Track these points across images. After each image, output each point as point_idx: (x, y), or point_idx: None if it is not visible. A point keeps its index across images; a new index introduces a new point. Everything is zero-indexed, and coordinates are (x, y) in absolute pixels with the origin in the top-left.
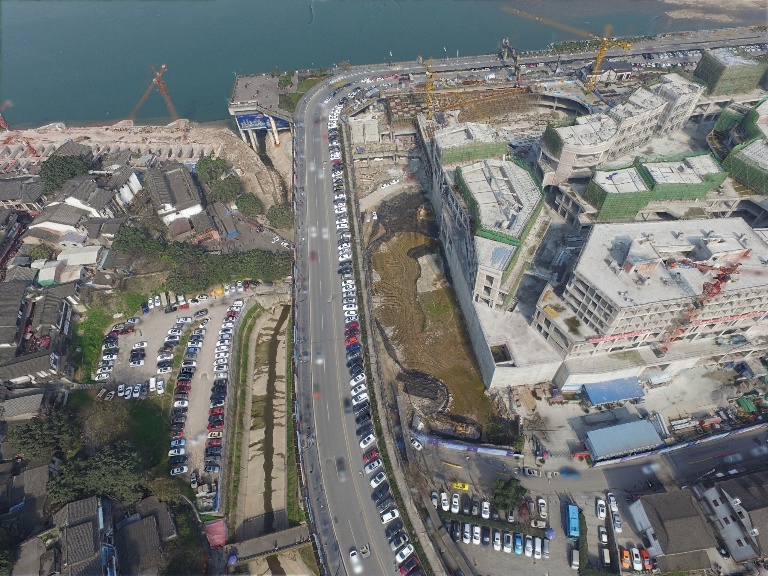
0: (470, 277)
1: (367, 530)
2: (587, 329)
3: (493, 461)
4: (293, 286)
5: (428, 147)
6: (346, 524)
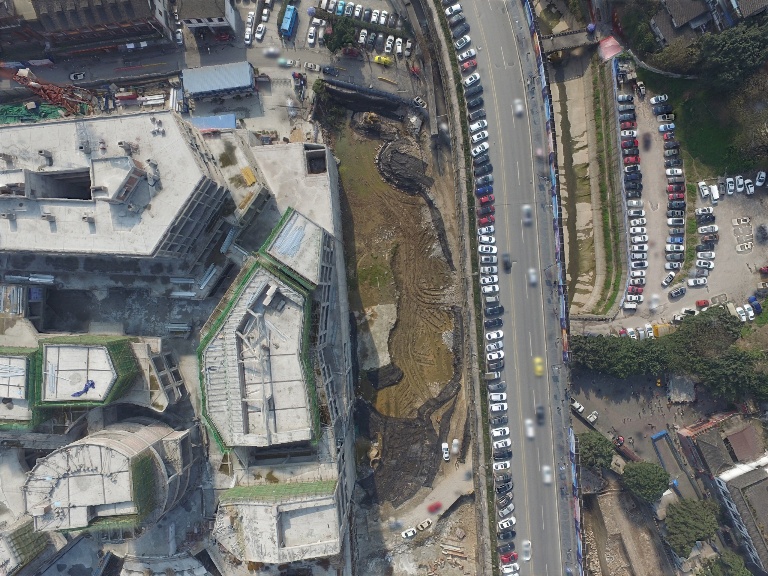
0: (331, 274)
1: (475, 1)
2: (214, 148)
3: (347, 80)
4: (565, 282)
5: (349, 575)
6: (494, 7)
